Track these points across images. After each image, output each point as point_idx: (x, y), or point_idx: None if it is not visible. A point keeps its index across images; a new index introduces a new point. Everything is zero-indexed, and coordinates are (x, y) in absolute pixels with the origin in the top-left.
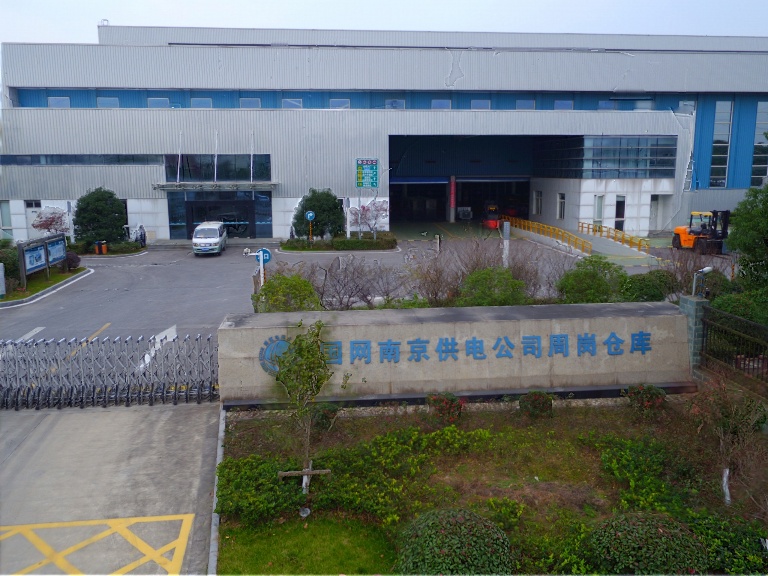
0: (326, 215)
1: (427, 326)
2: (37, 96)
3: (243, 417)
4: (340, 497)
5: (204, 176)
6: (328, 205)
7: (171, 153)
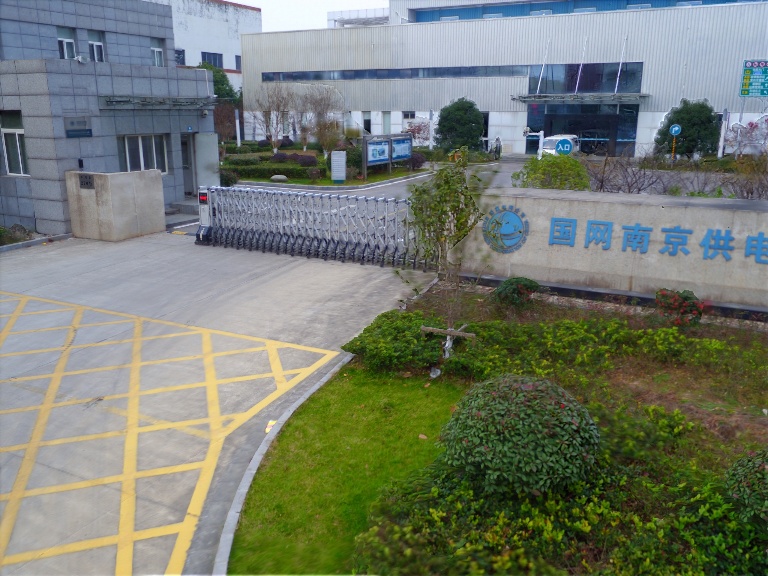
0: (695, 130)
1: (693, 211)
2: (432, 17)
3: (453, 287)
4: (472, 364)
5: (567, 87)
6: (700, 118)
7: (536, 63)
